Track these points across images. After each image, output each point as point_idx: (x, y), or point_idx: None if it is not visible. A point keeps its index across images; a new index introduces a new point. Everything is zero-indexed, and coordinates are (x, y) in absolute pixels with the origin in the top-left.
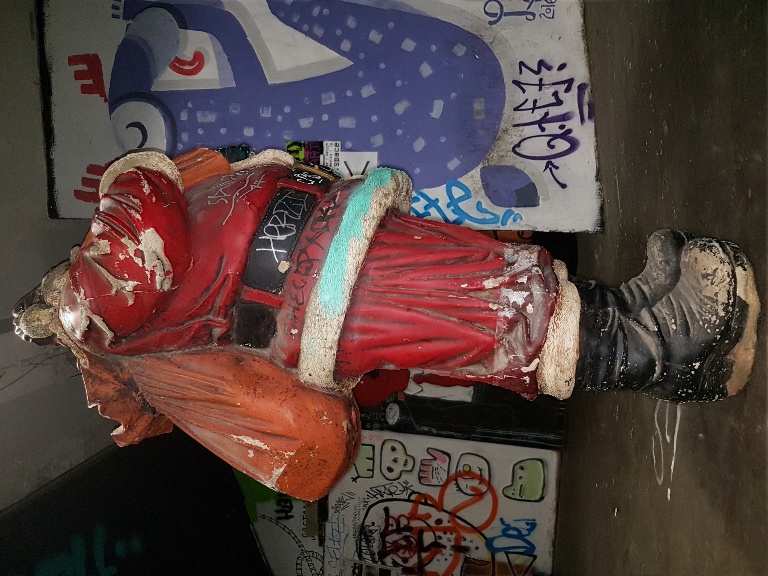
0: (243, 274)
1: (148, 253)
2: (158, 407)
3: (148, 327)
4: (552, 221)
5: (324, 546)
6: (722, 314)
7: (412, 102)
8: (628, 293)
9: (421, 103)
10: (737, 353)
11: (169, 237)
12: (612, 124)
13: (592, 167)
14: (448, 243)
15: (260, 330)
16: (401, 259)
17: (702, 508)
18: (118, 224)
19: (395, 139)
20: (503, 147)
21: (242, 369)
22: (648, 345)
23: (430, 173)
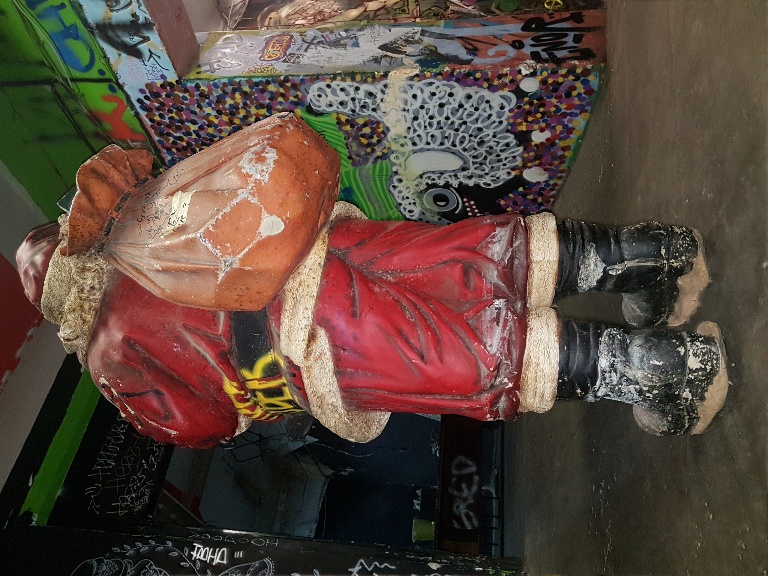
0: None
1: None
2: None
3: None
4: None
5: None
6: None
7: None
8: None
9: None
10: None
11: None
12: None
13: None
14: None
15: None
16: None
17: None
18: None
19: None
20: None
21: None
22: None
23: None
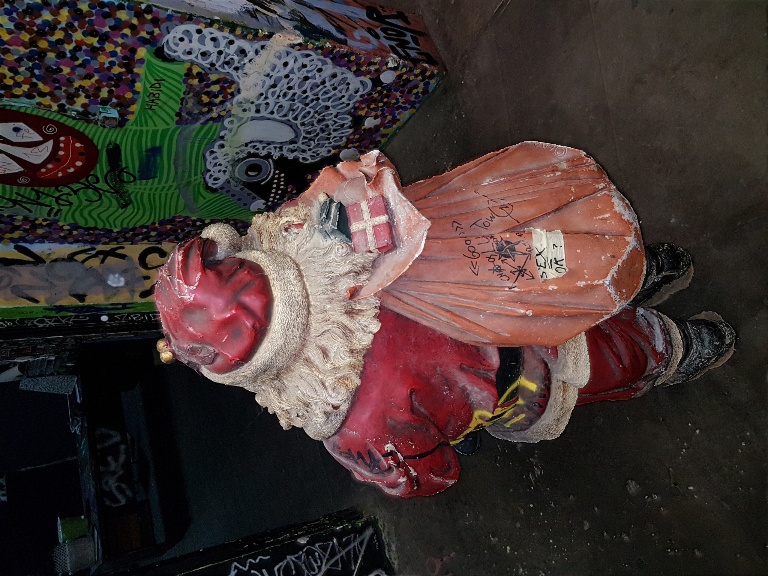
0: None
1: None
2: None
3: None
4: None
5: None
6: None
7: None
8: None
9: None
10: None
11: None
12: None
13: None
14: None
15: None
16: None
17: None
18: None
19: None
20: None
21: None
22: None
23: None
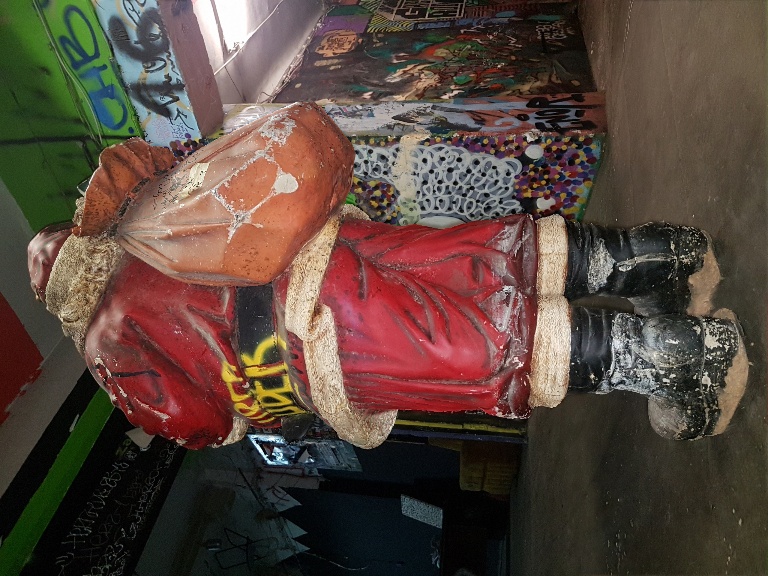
0: None
1: None
2: None
3: None
4: None
5: None
6: None
7: None
8: None
9: None
10: None
11: None
12: None
13: None
14: None
15: None
16: None
17: None
18: None
19: None
20: None
21: None
22: None
23: None
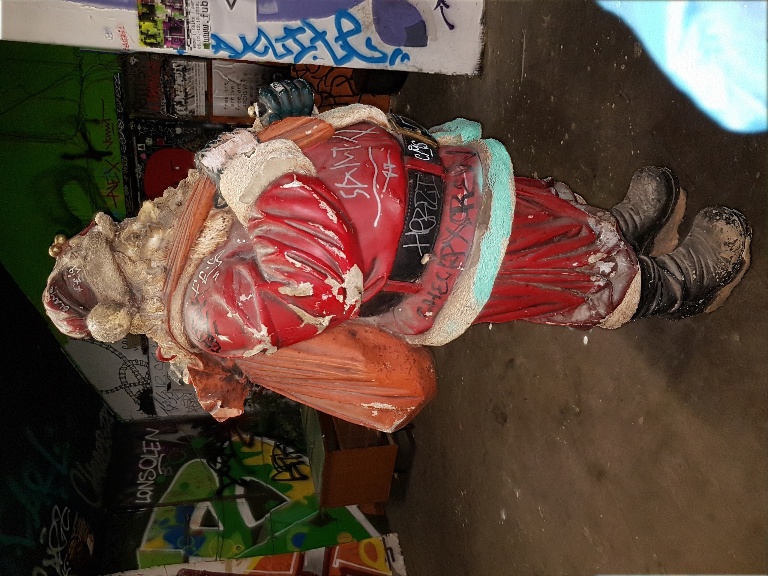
0: None
1: (350, 289)
2: None
3: None
4: (437, 63)
5: (148, 353)
6: (730, 270)
7: None
8: (623, 221)
9: None
10: (724, 290)
11: (363, 266)
12: None
13: (479, 9)
14: (550, 218)
15: (380, 308)
16: (524, 242)
17: (636, 363)
18: (316, 262)
19: None
20: None
21: (363, 345)
22: (676, 290)
23: (318, 0)
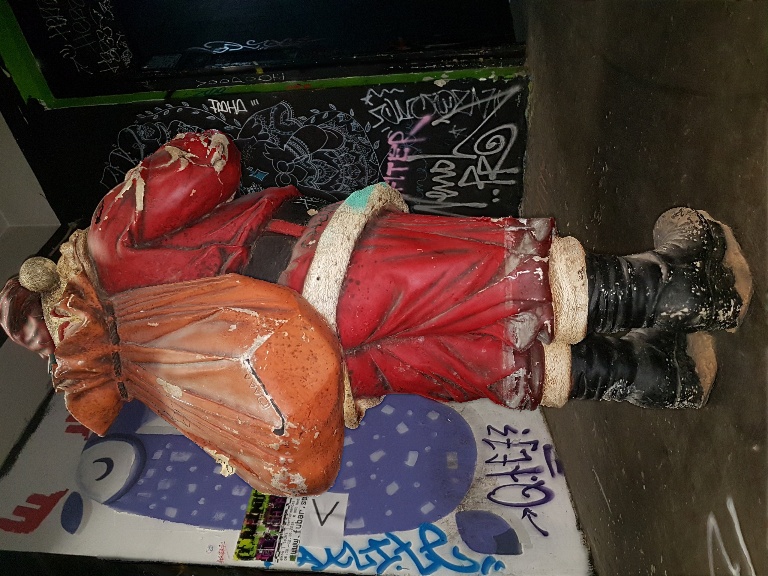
0: (275, 211)
1: (215, 142)
2: (122, 342)
3: (166, 240)
4: (539, 571)
5: None
6: (700, 227)
7: (388, 452)
8: None
9: (397, 453)
10: (730, 259)
11: (233, 147)
12: (580, 432)
13: (571, 516)
14: None
15: (272, 265)
16: None
17: None
18: None
19: (368, 483)
20: (478, 494)
21: None
22: (647, 259)
23: (403, 516)
